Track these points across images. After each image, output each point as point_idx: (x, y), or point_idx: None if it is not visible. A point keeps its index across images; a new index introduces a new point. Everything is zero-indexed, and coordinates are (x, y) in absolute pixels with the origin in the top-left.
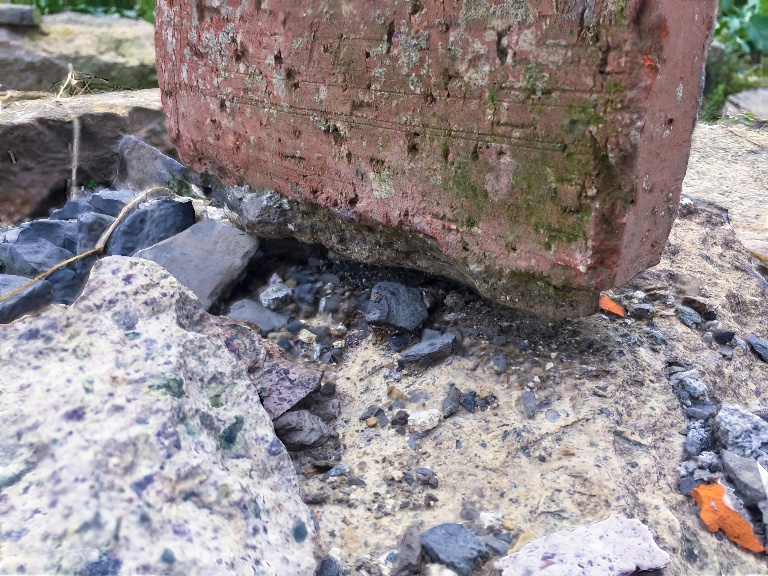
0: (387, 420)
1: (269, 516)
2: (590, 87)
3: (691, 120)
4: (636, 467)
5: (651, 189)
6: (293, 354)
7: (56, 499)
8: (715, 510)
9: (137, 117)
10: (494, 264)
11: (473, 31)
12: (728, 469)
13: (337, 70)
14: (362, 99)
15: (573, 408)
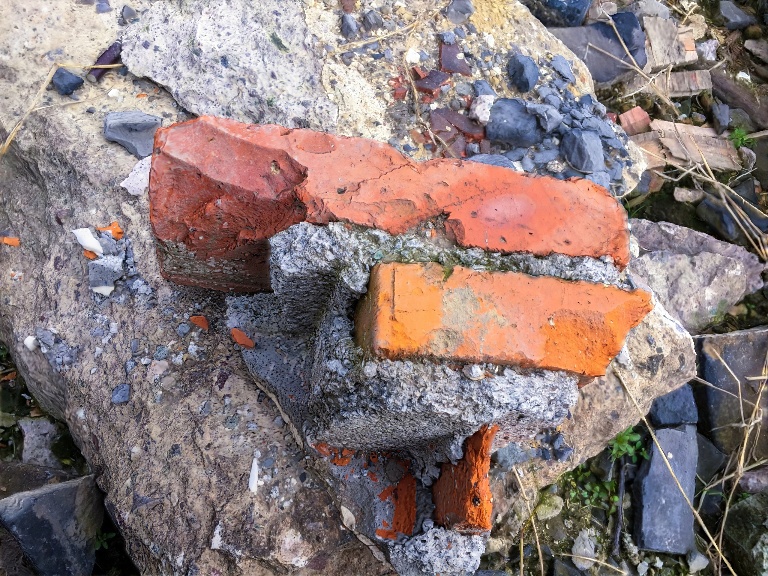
0: None
1: None
2: None
3: None
4: None
5: None
6: None
7: (250, 63)
8: (113, 226)
9: None
10: None
11: None
12: None
13: None
14: None
15: None
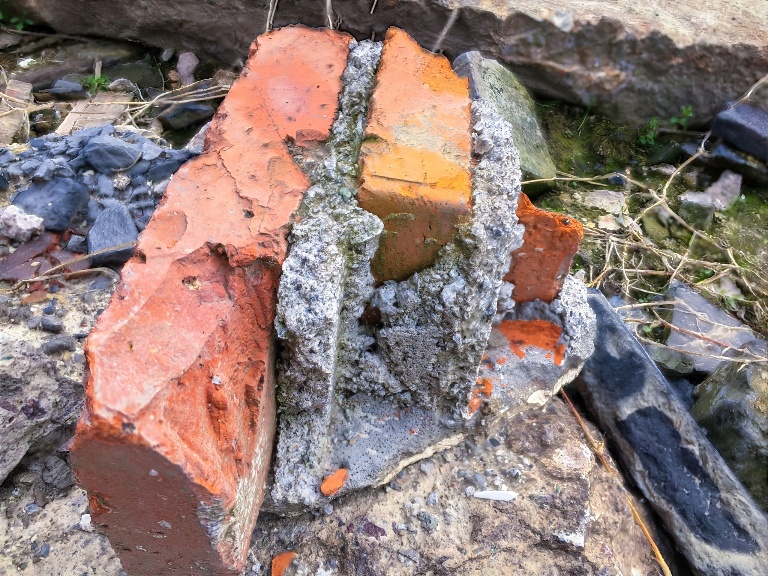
0: None
1: None
2: None
3: (205, 541)
4: None
5: None
6: None
7: None
8: None
9: (515, 22)
10: None
11: None
12: None
13: None
14: None
15: None
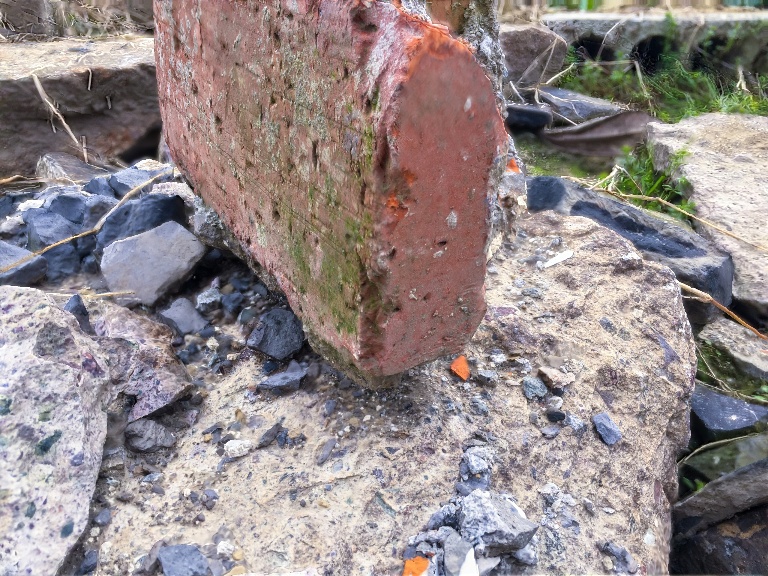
0: (219, 439)
1: (43, 515)
2: (356, 213)
3: (481, 238)
4: (374, 528)
5: (427, 298)
6: (197, 358)
7: None
8: None
9: None
10: (314, 330)
11: (301, 135)
12: (443, 549)
13: (238, 130)
14: (250, 161)
15: (356, 463)
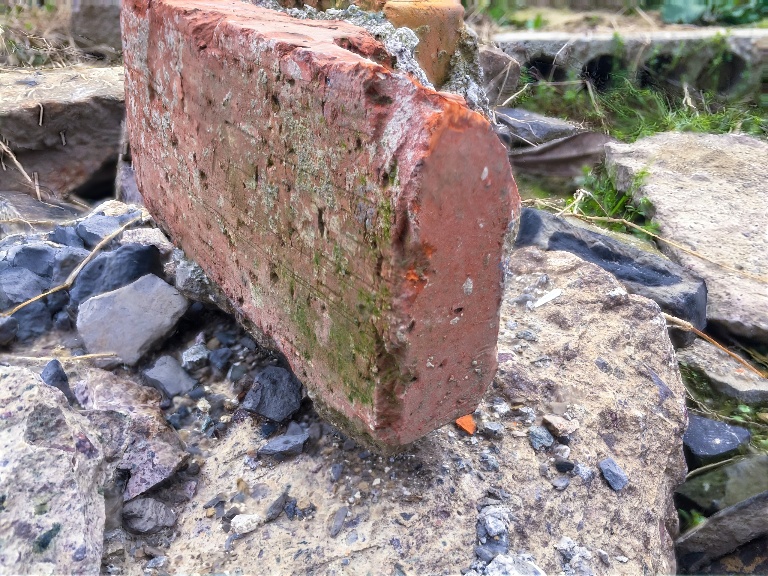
0: (223, 513)
1: None
2: (371, 284)
3: (494, 301)
4: None
5: (443, 364)
6: (188, 421)
7: None
8: None
9: None
10: (321, 397)
11: (304, 200)
12: None
13: (228, 188)
14: (243, 220)
15: (372, 533)
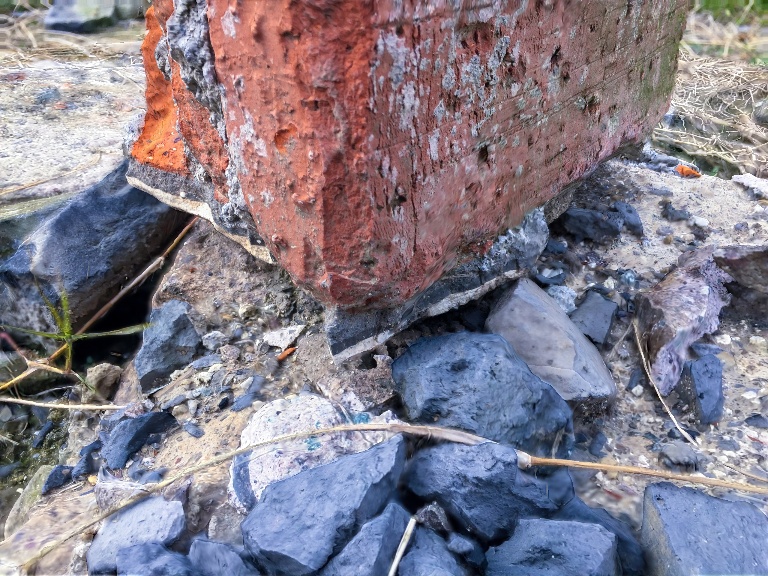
0: None
1: None
2: None
3: None
4: None
5: None
6: None
7: None
8: None
9: None
10: None
11: None
12: None
13: None
14: None
15: None
